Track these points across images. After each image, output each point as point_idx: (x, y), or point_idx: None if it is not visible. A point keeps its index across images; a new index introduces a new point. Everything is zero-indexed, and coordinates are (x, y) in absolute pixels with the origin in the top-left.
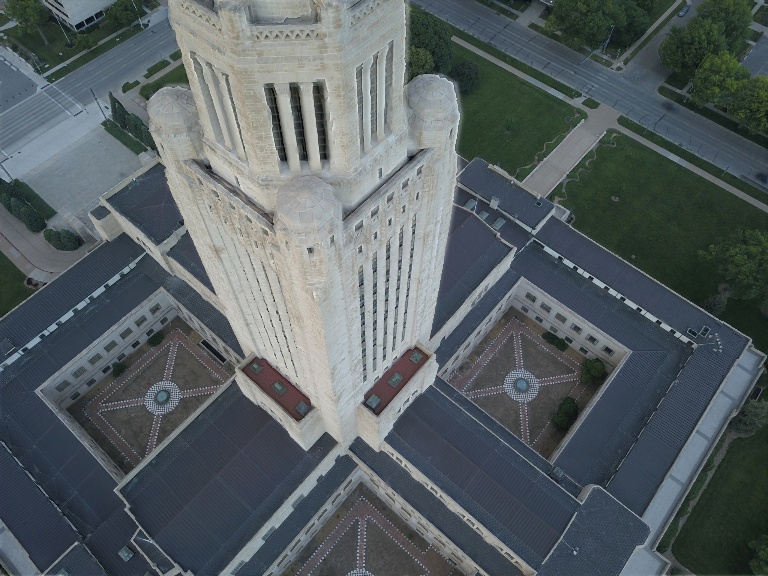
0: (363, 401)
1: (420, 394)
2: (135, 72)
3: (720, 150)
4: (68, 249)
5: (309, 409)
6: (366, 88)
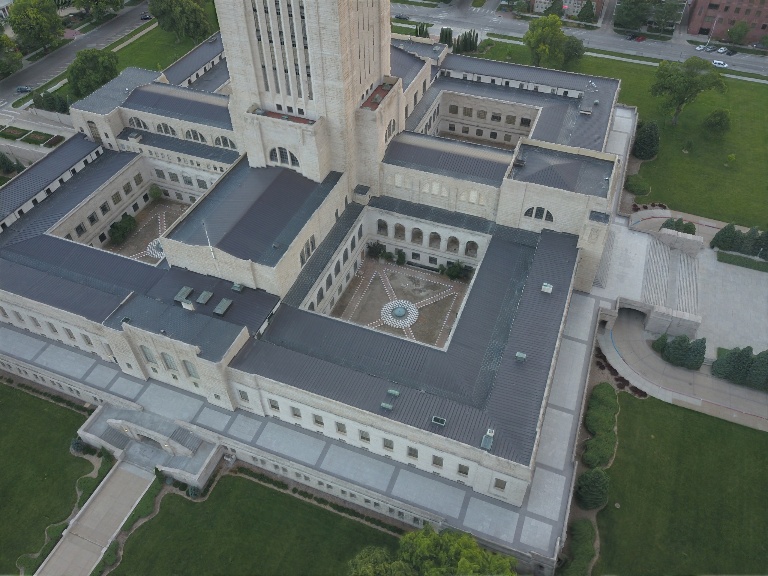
0: None
1: None
2: None
3: None
4: None
5: None
6: None
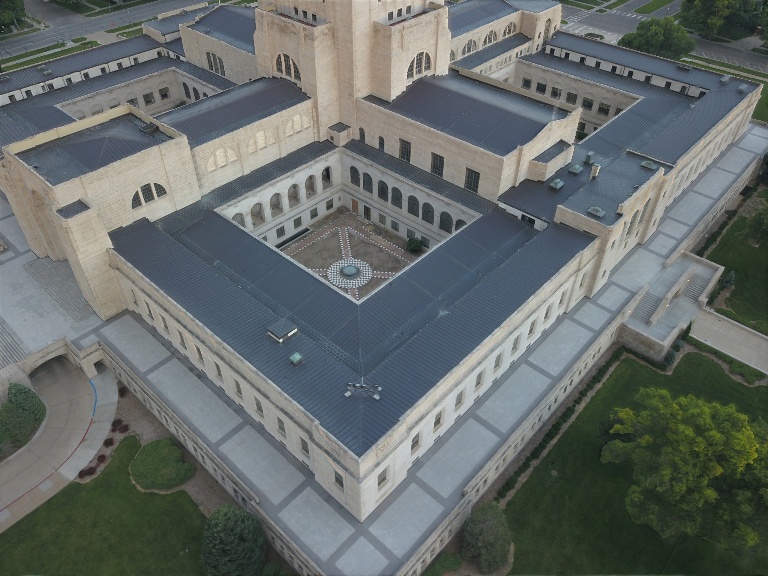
0: None
1: None
2: None
3: (170, 6)
4: (40, 418)
5: (430, 8)
6: None
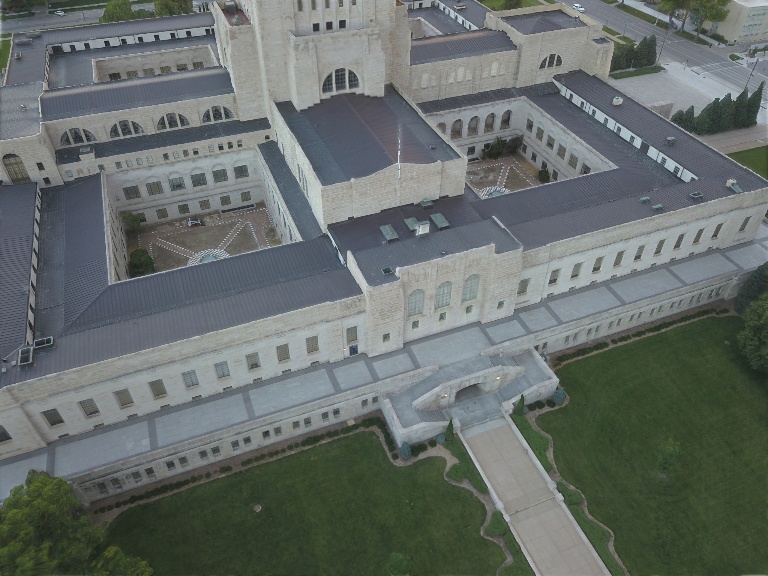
0: None
1: None
2: None
3: None
4: None
5: None
6: None
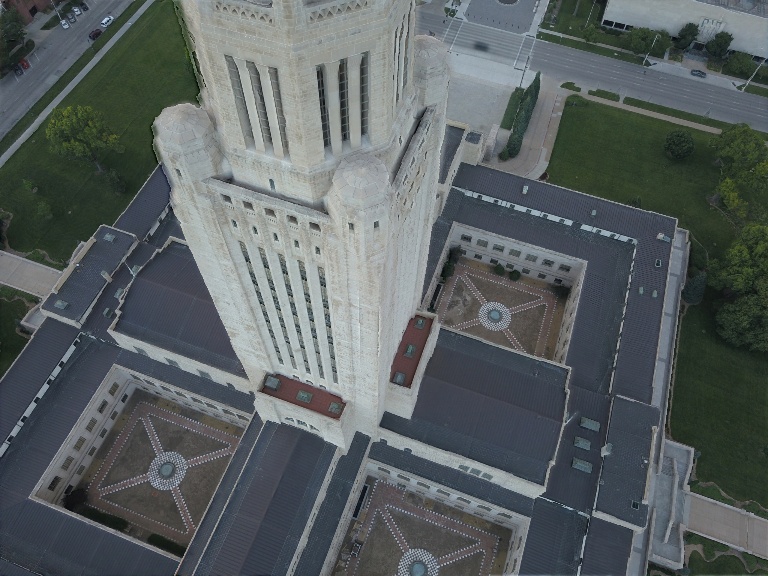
0: (270, 373)
1: (323, 438)
2: (589, 83)
3: None
4: None
5: None
6: (246, 87)
